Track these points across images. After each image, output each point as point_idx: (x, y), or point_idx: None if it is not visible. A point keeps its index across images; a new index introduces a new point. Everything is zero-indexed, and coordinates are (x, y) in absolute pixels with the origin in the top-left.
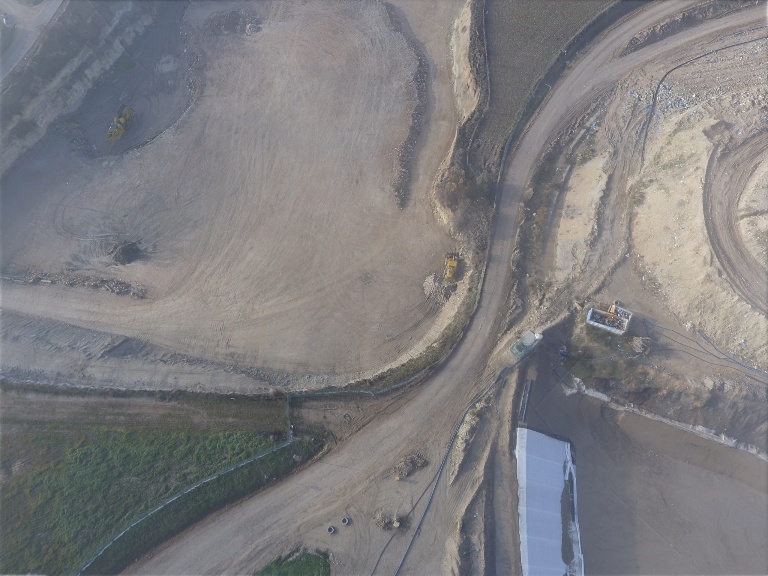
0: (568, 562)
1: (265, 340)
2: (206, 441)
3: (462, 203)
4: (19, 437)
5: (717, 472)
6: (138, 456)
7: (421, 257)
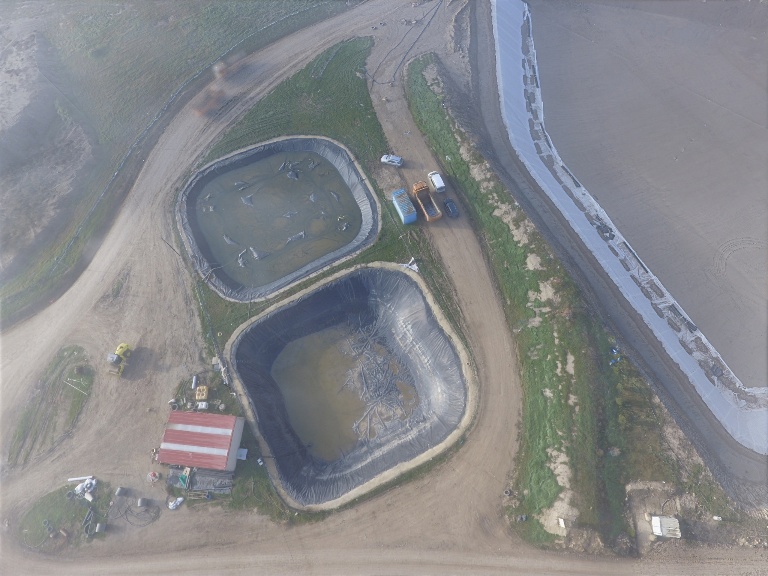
0: (526, 54)
1: None
2: None
3: None
4: (170, 5)
5: (625, 7)
6: (247, 7)
7: None
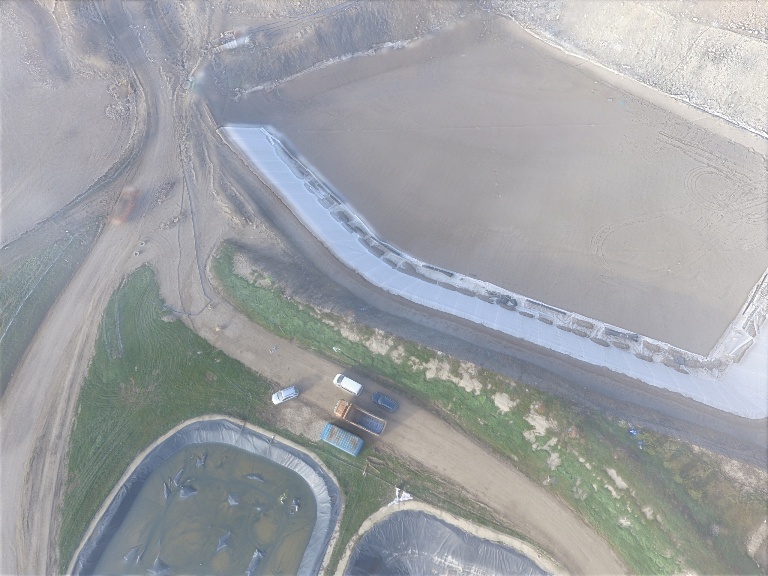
0: (302, 178)
1: (15, 221)
2: (7, 281)
3: (88, 48)
4: None
5: (348, 84)
6: None
7: (93, 103)
